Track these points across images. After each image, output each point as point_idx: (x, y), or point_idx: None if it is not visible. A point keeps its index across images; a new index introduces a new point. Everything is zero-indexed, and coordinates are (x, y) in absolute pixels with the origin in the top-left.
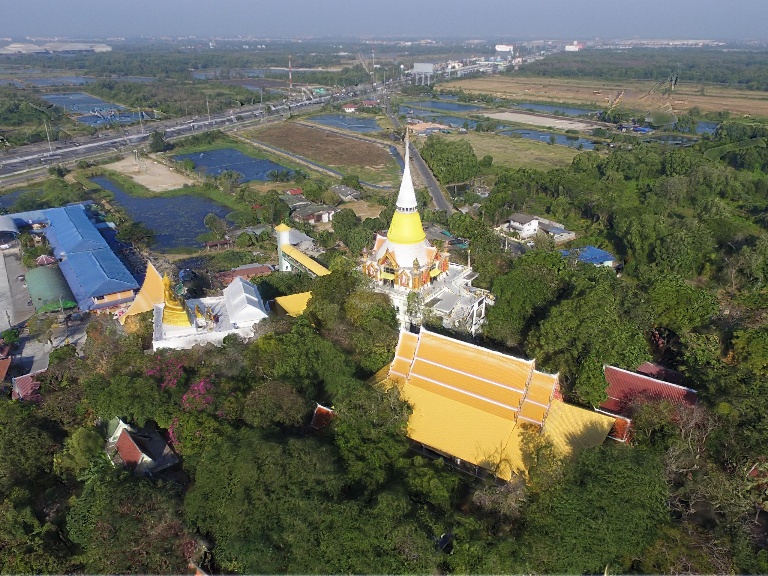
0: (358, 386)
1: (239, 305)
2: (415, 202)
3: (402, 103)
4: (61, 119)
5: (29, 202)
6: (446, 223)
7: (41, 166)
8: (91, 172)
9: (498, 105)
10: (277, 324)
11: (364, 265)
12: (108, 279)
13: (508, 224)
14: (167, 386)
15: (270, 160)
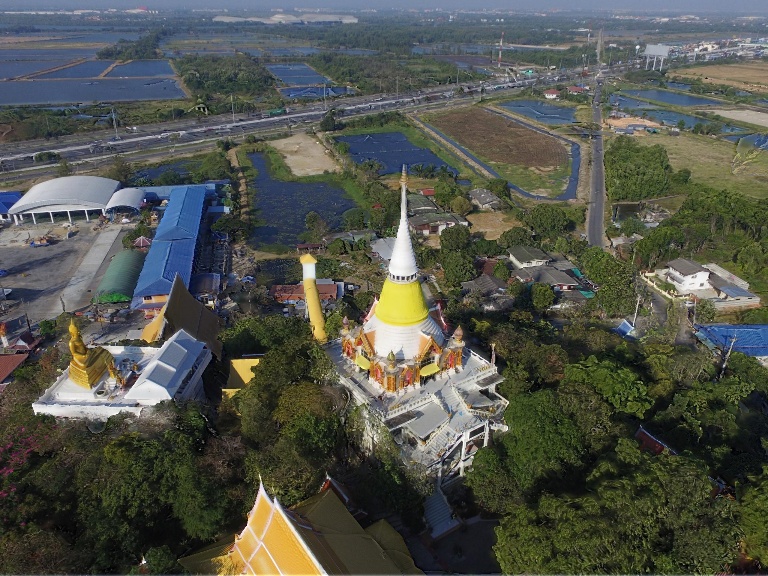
0: (160, 568)
1: (143, 376)
2: (411, 269)
3: (617, 91)
4: (267, 90)
5: (171, 176)
6: (580, 258)
7: (217, 137)
8: (253, 148)
9: (739, 100)
10: (164, 416)
11: (343, 339)
12: (161, 278)
13: (667, 270)
14: (2, 475)
15: (430, 150)
